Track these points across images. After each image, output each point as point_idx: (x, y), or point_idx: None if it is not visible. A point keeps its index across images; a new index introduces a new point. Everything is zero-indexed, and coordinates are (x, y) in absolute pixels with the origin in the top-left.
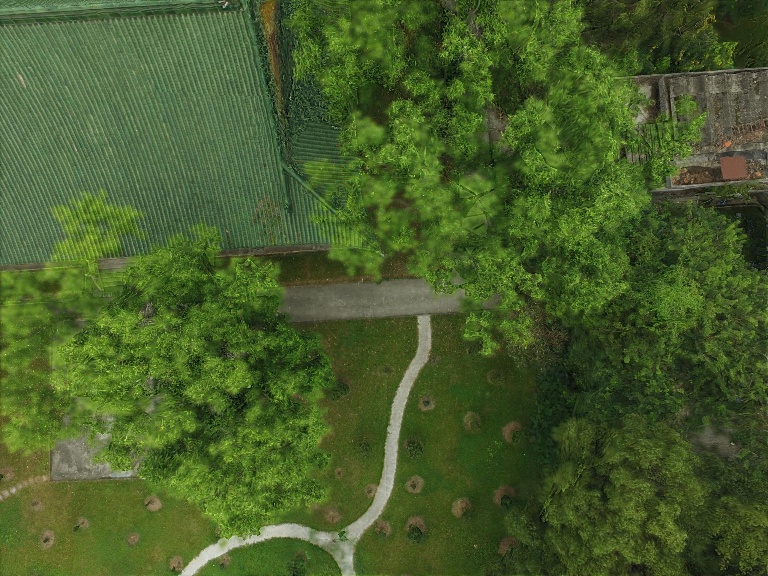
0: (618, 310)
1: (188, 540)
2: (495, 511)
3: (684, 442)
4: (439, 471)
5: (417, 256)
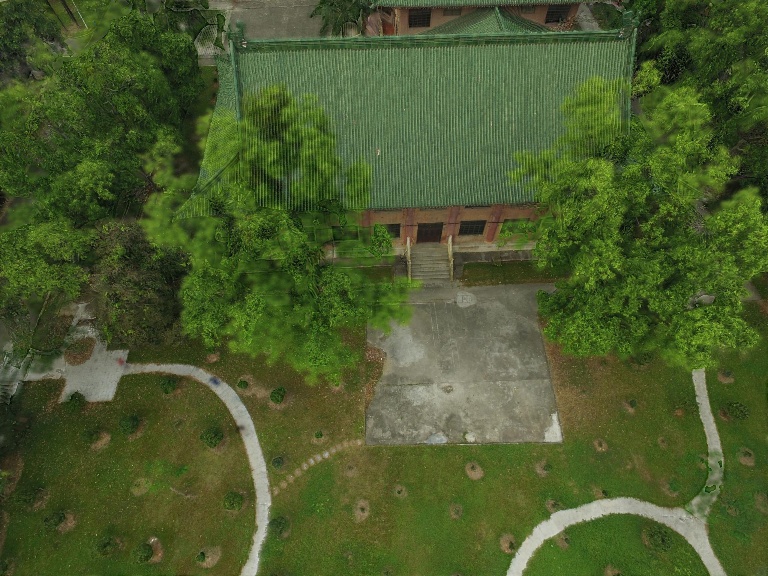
0: None
1: (517, 514)
2: None
3: None
4: (766, 442)
5: None
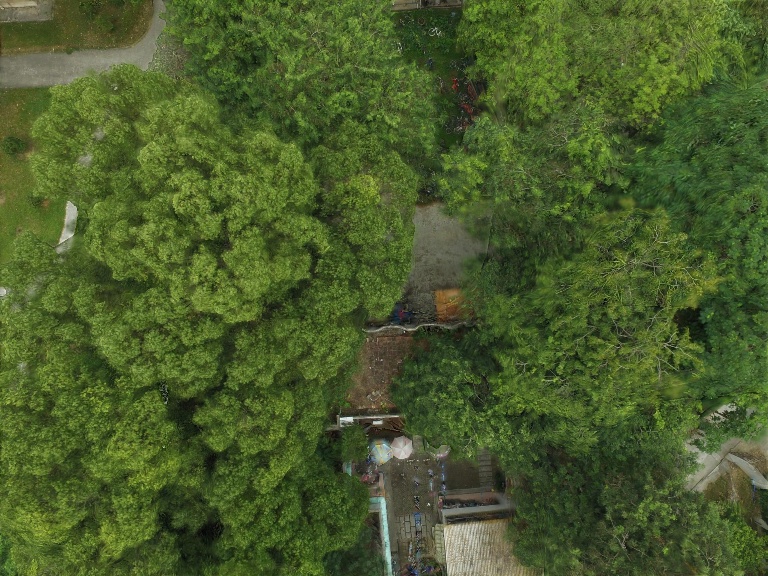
0: (197, 7)
1: None
2: None
3: (185, 81)
4: None
5: (96, 19)
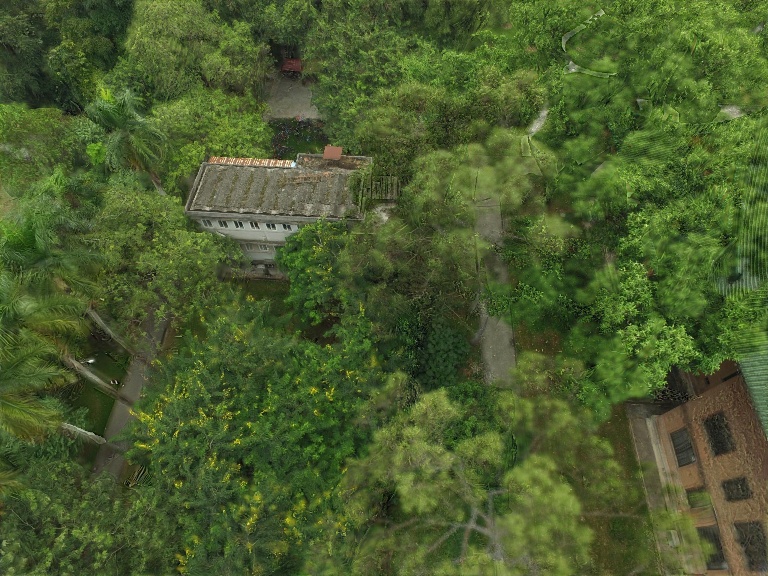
0: None
1: None
2: None
3: (436, 0)
4: None
5: None
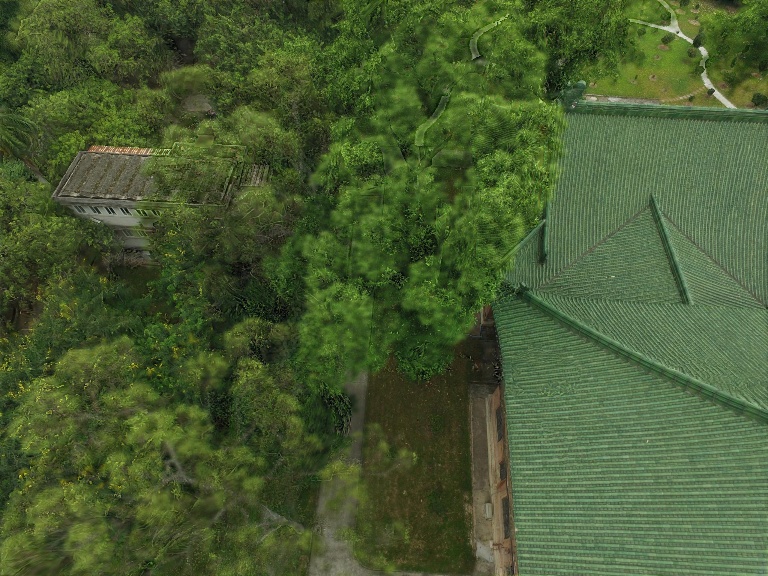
0: None
1: None
2: (388, 65)
3: None
4: None
5: None
